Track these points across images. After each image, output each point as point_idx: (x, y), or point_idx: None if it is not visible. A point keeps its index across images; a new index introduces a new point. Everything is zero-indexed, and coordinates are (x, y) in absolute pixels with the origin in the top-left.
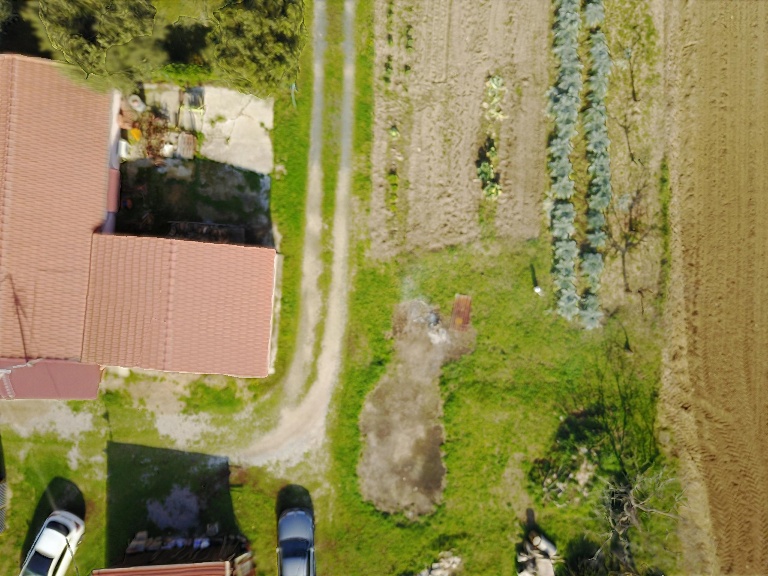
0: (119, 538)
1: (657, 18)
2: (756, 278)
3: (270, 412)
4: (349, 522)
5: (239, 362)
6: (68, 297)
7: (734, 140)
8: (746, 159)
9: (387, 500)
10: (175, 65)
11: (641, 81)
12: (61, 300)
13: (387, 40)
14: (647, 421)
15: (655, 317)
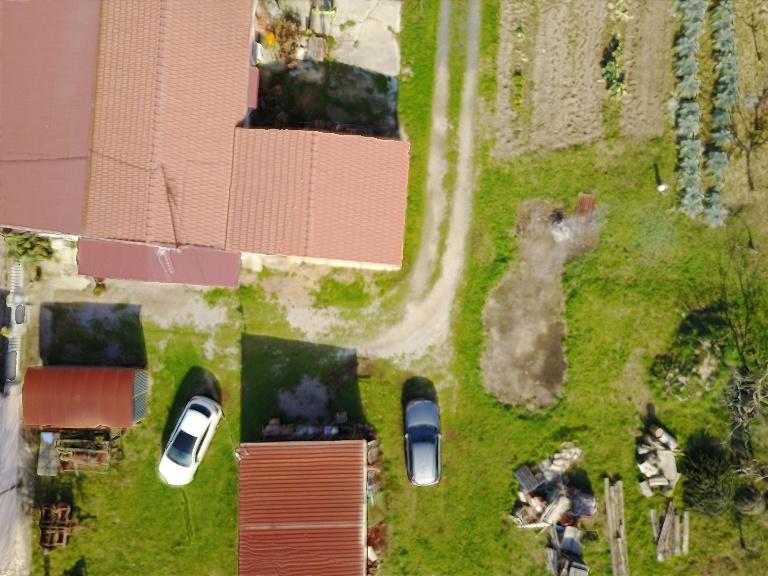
0: (253, 424)
1: None
2: None
3: (396, 307)
4: (473, 413)
5: (376, 251)
6: (213, 188)
7: None
8: None
9: (510, 393)
10: None
11: None
12: (207, 190)
13: None
14: None
15: None
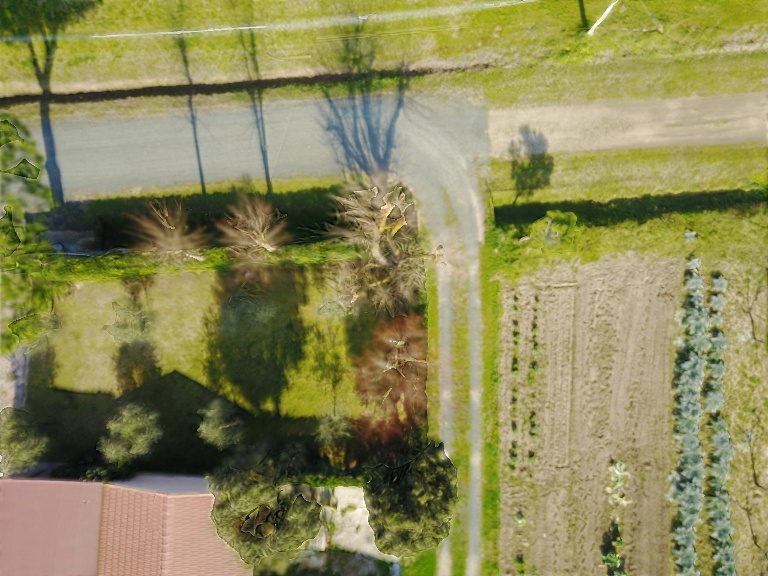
0: None
1: None
2: None
3: None
4: None
5: None
6: None
7: None
8: None
9: None
10: (312, 477)
11: (761, 463)
12: None
13: (511, 426)
14: None
15: None
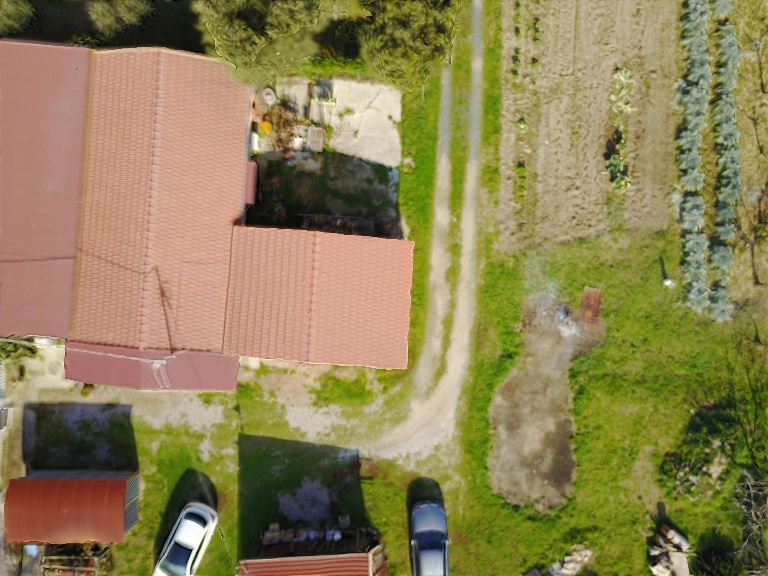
0: (251, 530)
1: None
2: None
3: (400, 404)
4: (480, 515)
5: (380, 354)
6: (210, 289)
7: None
8: None
9: (517, 493)
10: (311, 58)
11: None
12: (203, 292)
13: (514, 33)
14: None
15: None
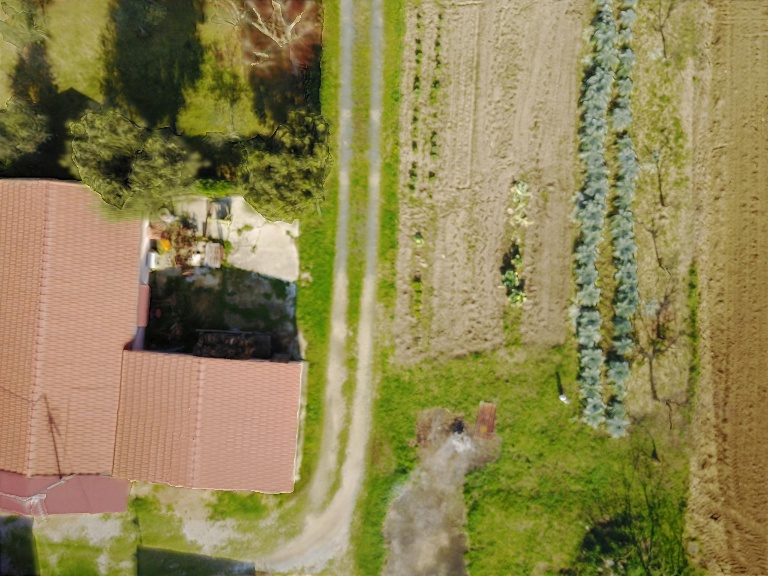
0: None
1: (685, 121)
2: None
3: (296, 518)
4: None
5: (266, 478)
6: (100, 413)
7: (765, 245)
8: None
9: None
10: (202, 181)
11: (669, 185)
12: (93, 416)
13: (411, 147)
14: (675, 532)
15: (683, 426)
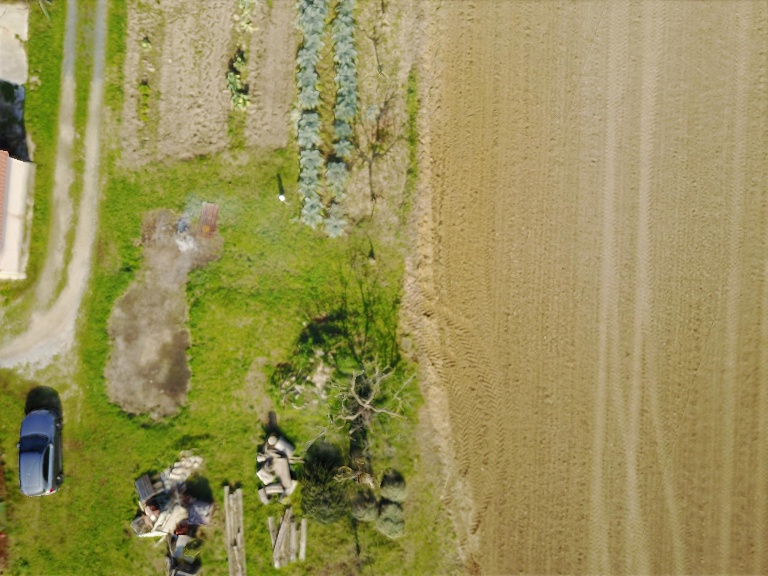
0: None
1: None
2: (498, 188)
3: (21, 316)
4: (97, 422)
5: None
6: None
7: (480, 52)
8: (491, 71)
9: (134, 402)
10: None
11: None
12: None
13: None
14: (389, 328)
15: (399, 226)
